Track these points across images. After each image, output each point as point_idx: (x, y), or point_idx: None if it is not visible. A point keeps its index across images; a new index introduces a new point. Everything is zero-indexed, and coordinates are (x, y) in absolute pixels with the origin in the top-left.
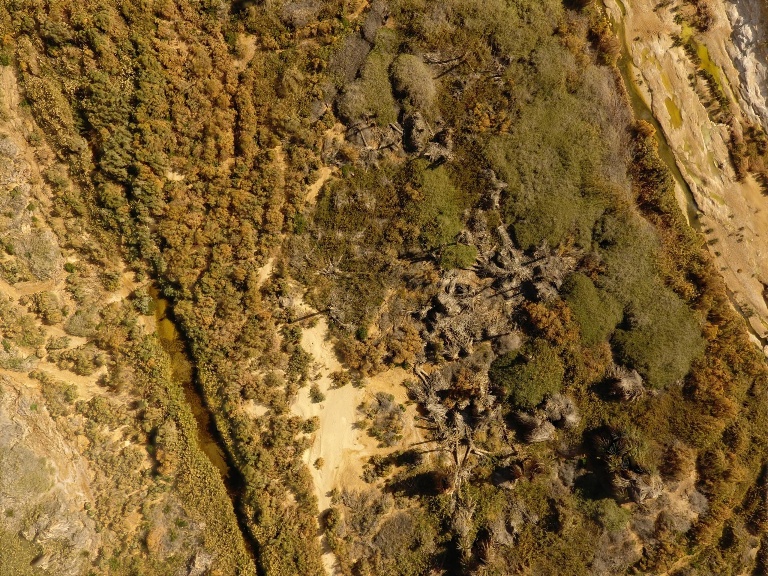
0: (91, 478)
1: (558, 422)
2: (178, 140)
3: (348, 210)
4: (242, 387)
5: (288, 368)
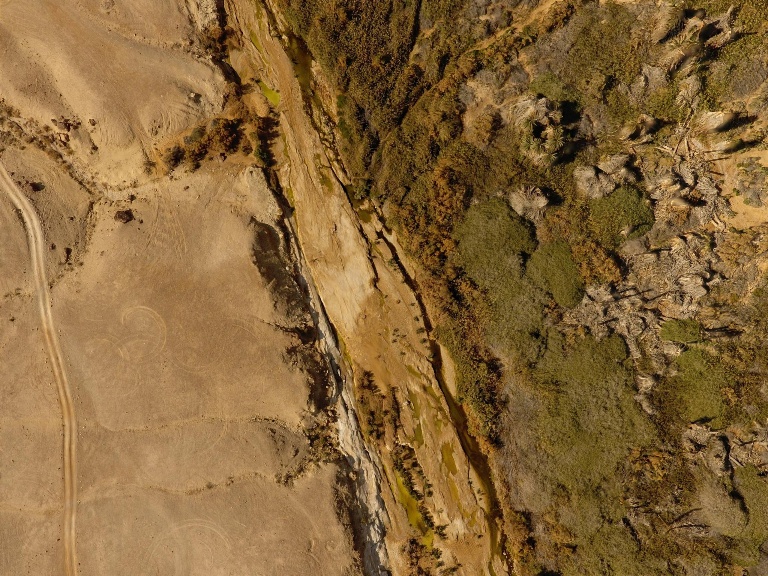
0: None
1: (598, 172)
2: None
3: None
4: None
5: None
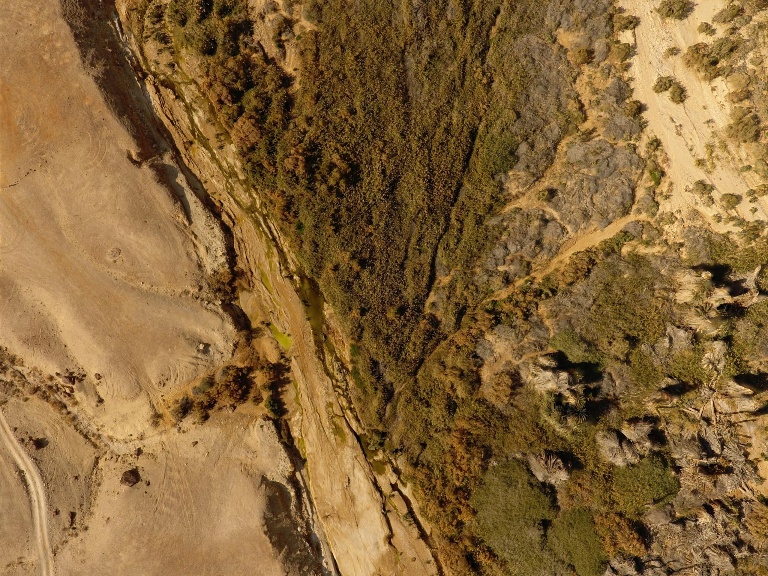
0: None
1: (621, 439)
2: None
3: None
4: None
5: None
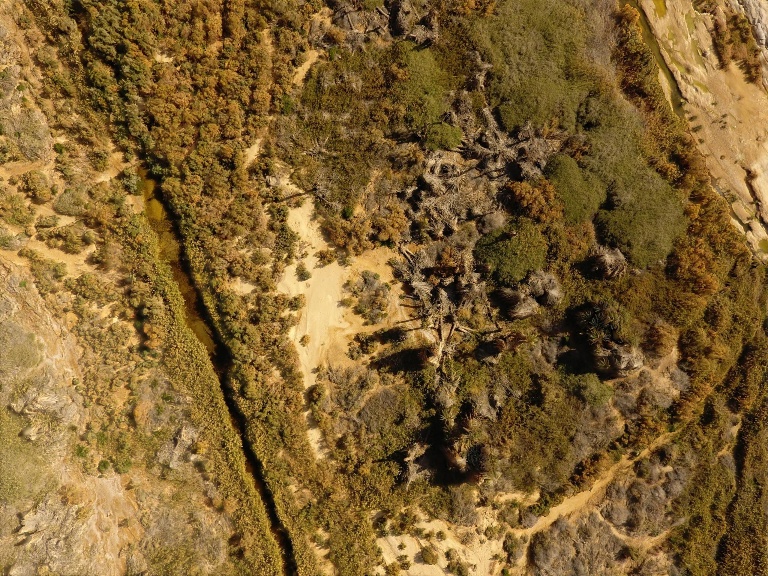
0: (79, 354)
1: (541, 298)
2: (167, 22)
3: (334, 91)
4: (229, 263)
5: (275, 246)
